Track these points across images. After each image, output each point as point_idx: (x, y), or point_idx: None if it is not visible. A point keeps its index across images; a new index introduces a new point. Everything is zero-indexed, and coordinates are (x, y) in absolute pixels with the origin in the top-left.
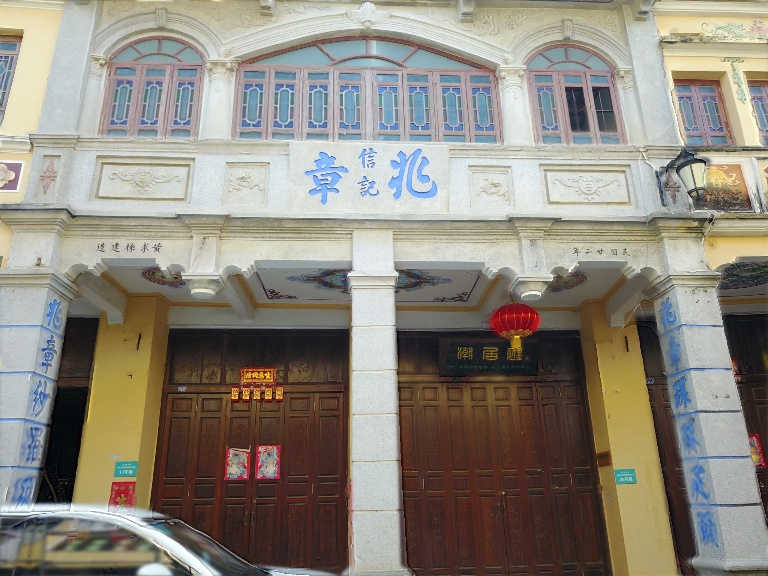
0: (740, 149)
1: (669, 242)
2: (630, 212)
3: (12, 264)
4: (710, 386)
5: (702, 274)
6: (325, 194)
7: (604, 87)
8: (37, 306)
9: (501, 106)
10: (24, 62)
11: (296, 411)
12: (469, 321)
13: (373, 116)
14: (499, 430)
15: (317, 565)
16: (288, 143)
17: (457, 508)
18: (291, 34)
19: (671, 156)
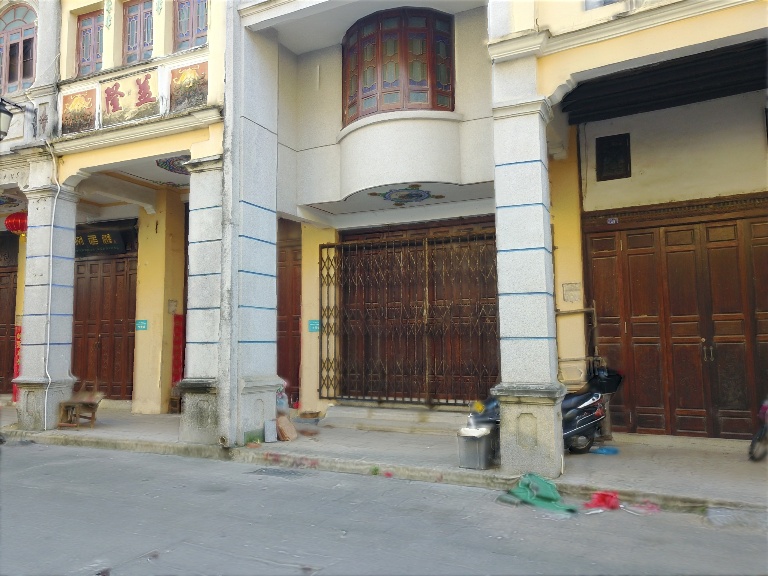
0: (91, 76)
1: (32, 165)
2: None
3: None
4: (33, 268)
5: (39, 188)
6: None
7: (31, 38)
8: None
9: None
10: None
11: (2, 284)
12: (78, 217)
13: None
14: (103, 293)
15: (7, 376)
16: None
17: (75, 345)
18: None
19: (45, 94)
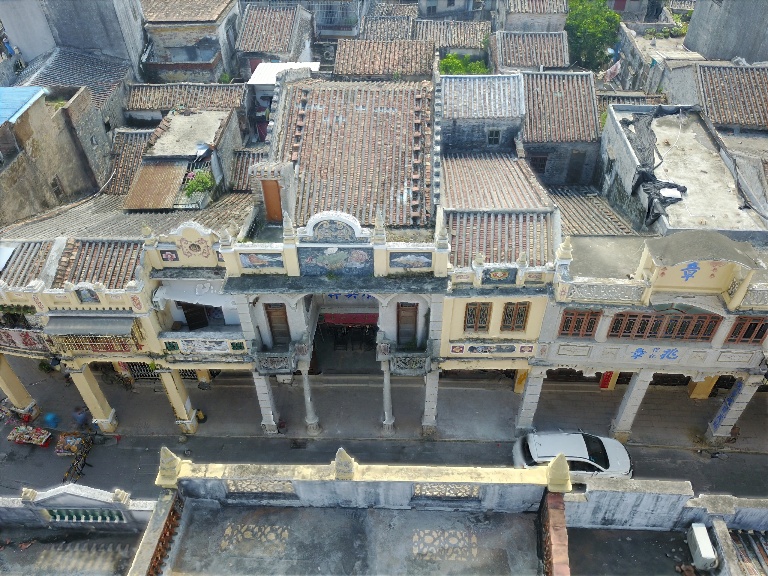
0: None
1: None
2: (745, 366)
3: (533, 373)
4: None
5: None
6: (636, 357)
7: None
8: (541, 382)
9: (718, 328)
10: (533, 314)
11: None
12: None
13: (664, 330)
14: None
15: None
16: (628, 345)
17: None
18: None
19: None
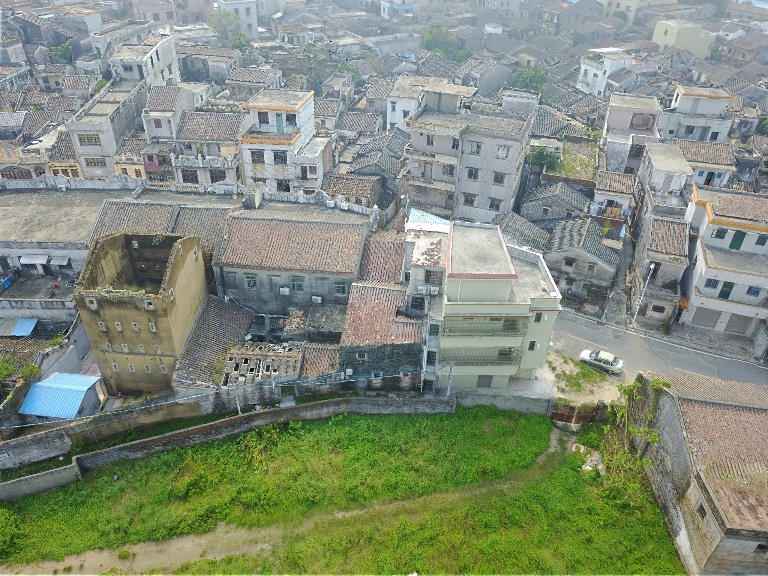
0: None
1: None
2: None
3: None
4: None
5: None
6: None
7: None
8: None
9: None
10: None
11: None
12: None
13: None
14: None
15: None
16: None
17: None
18: (4, 167)
19: None
